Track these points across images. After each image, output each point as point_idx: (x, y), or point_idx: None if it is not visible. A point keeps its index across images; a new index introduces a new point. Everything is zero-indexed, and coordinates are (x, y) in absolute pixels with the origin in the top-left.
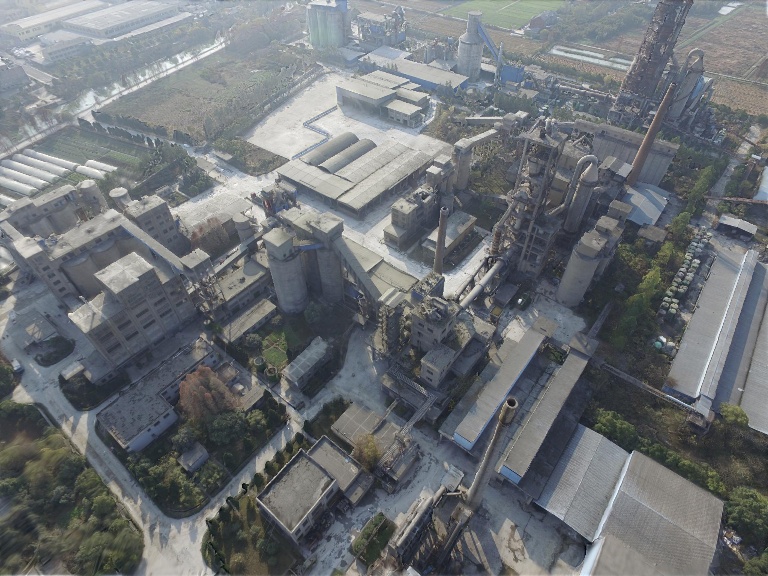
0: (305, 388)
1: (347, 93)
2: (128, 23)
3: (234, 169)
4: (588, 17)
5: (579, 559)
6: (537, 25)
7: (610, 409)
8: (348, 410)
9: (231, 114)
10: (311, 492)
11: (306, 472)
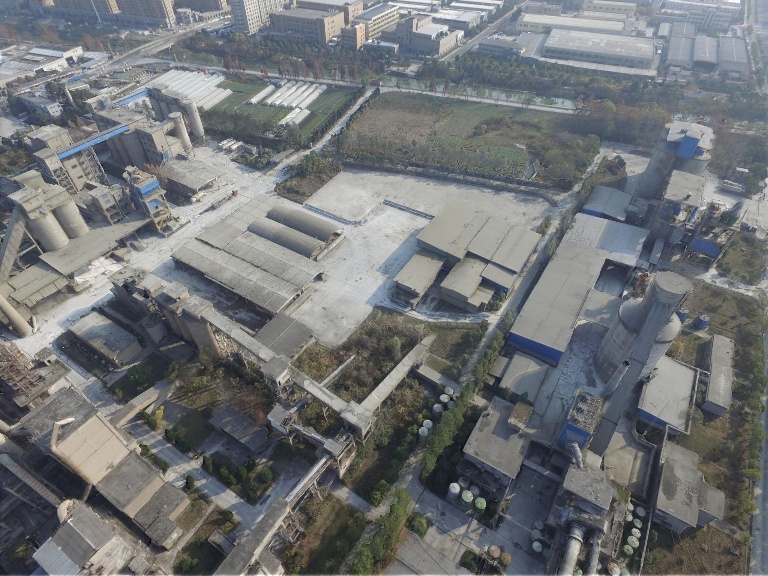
0: None
1: None
2: (577, 52)
3: (289, 175)
4: None
5: None
6: None
7: None
8: None
9: (377, 147)
10: None
11: None
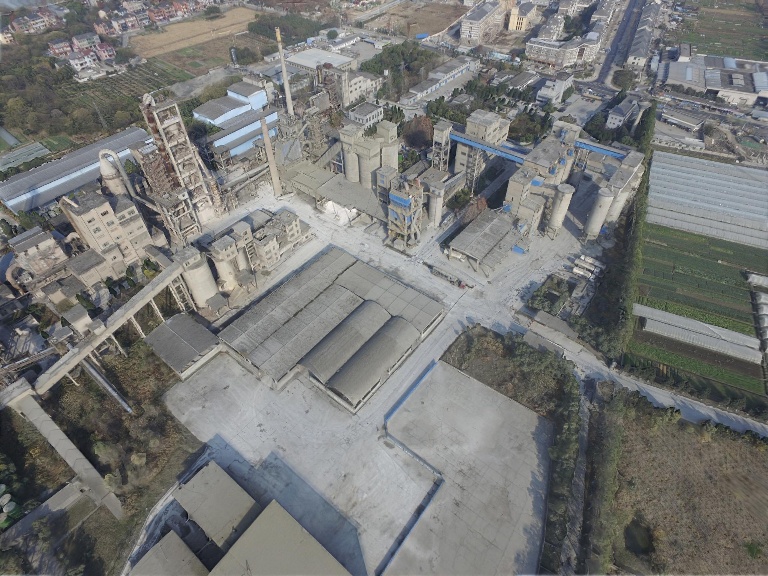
0: None
1: None
2: None
3: None
4: None
5: None
6: None
7: None
8: None
9: None
10: (360, 109)
11: (363, 113)
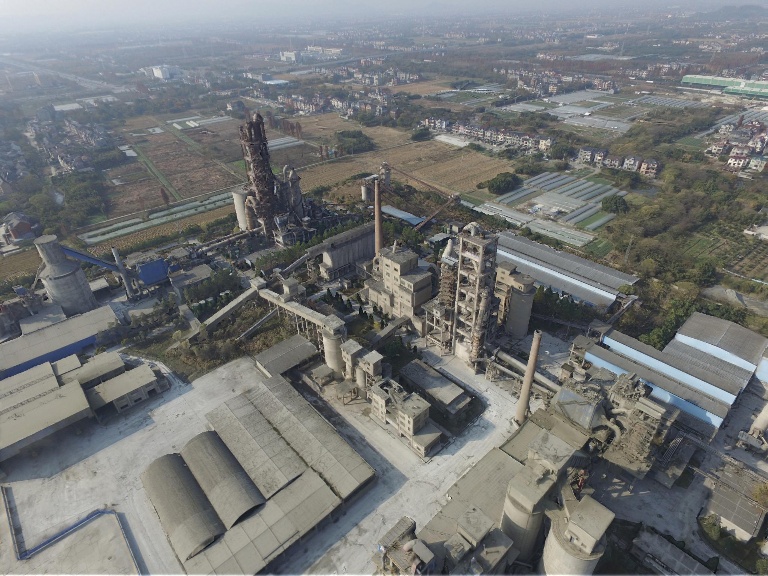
0: (714, 567)
1: (9, 451)
2: None
3: None
4: (49, 202)
5: (758, 387)
6: (23, 231)
7: (636, 338)
8: (725, 516)
9: None
10: None
11: None
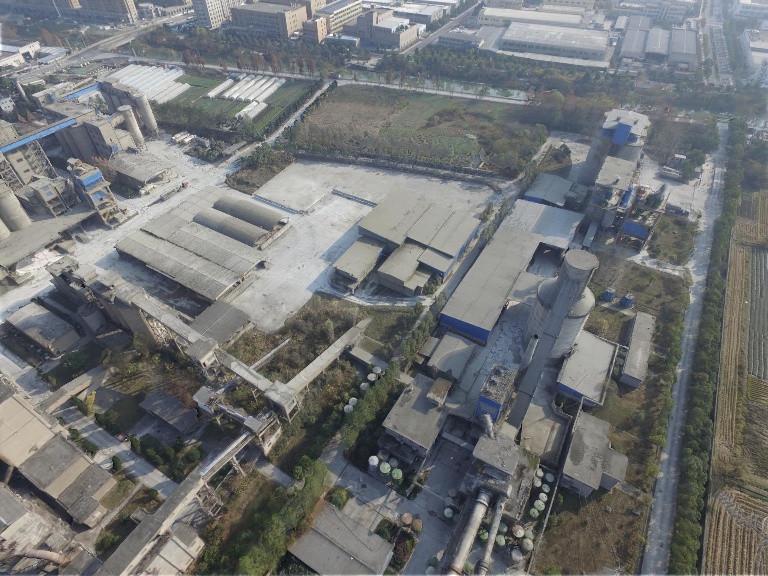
0: None
1: None
2: (534, 44)
3: (240, 167)
4: None
5: None
6: None
7: None
8: None
9: (329, 139)
10: None
11: None
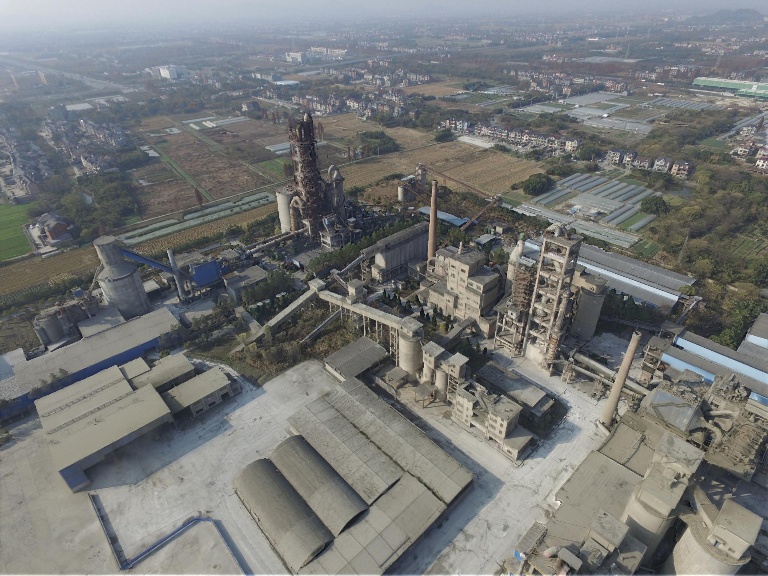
0: None
1: (95, 457)
2: None
3: None
4: (80, 203)
5: None
6: (60, 232)
7: None
8: None
9: None
10: None
11: None
